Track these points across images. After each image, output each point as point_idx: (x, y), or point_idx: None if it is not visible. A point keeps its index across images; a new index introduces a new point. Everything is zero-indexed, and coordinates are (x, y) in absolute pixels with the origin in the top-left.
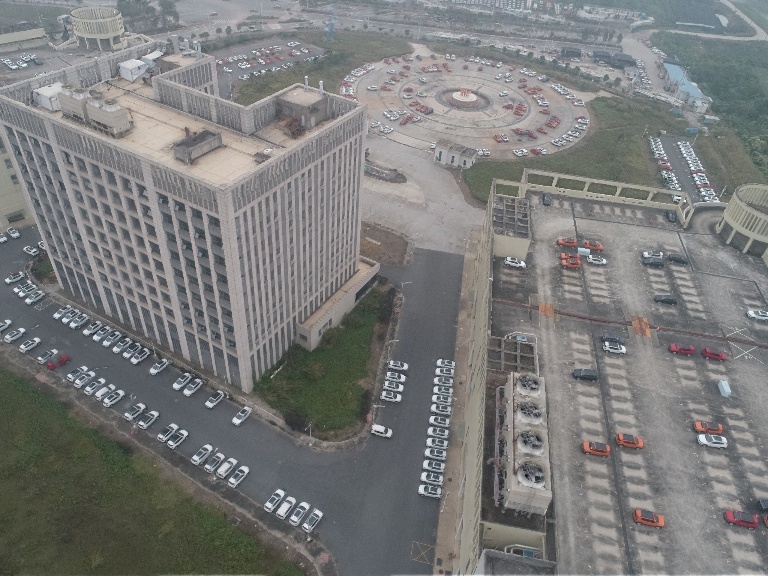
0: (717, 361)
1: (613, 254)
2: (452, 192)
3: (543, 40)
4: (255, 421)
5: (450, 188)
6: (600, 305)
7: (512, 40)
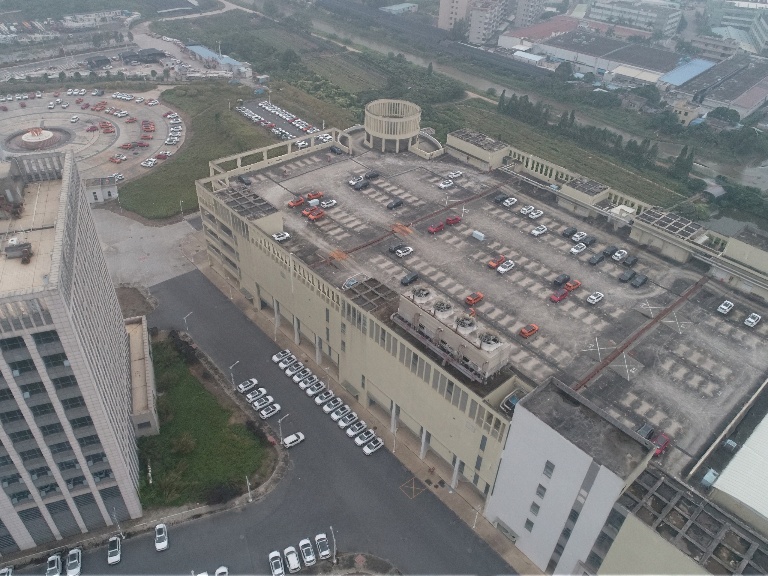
0: (458, 223)
1: (332, 194)
2: (125, 225)
3: (57, 59)
4: (178, 530)
5: (119, 222)
6: (364, 232)
7: (24, 68)
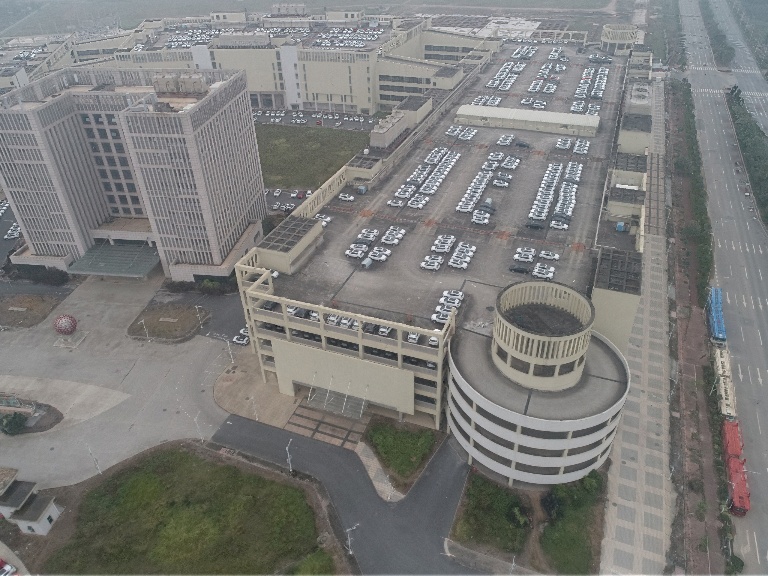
0: None
1: None
2: None
3: None
4: None
5: None
6: None
7: None
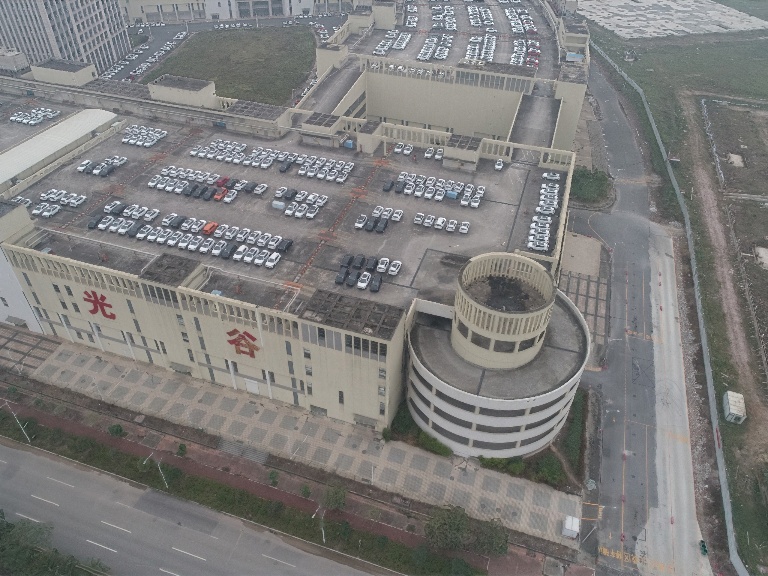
0: None
1: None
2: None
3: None
4: None
5: None
6: None
7: None
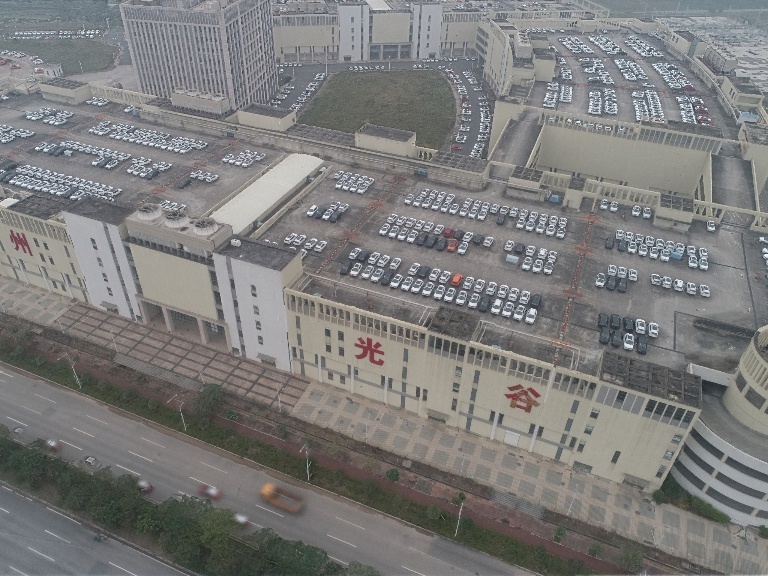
0: None
1: None
2: (97, 74)
3: None
4: None
5: (92, 75)
6: None
7: None
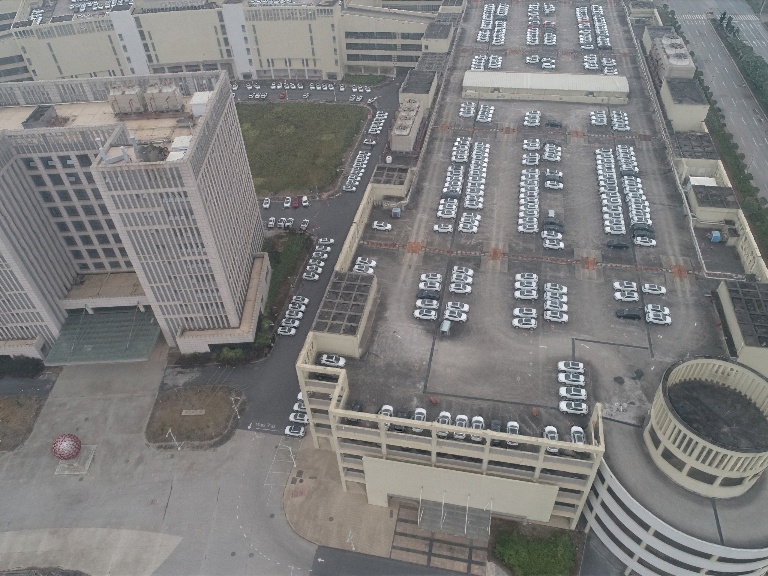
0: None
1: None
2: None
3: None
4: None
5: None
6: None
7: None
